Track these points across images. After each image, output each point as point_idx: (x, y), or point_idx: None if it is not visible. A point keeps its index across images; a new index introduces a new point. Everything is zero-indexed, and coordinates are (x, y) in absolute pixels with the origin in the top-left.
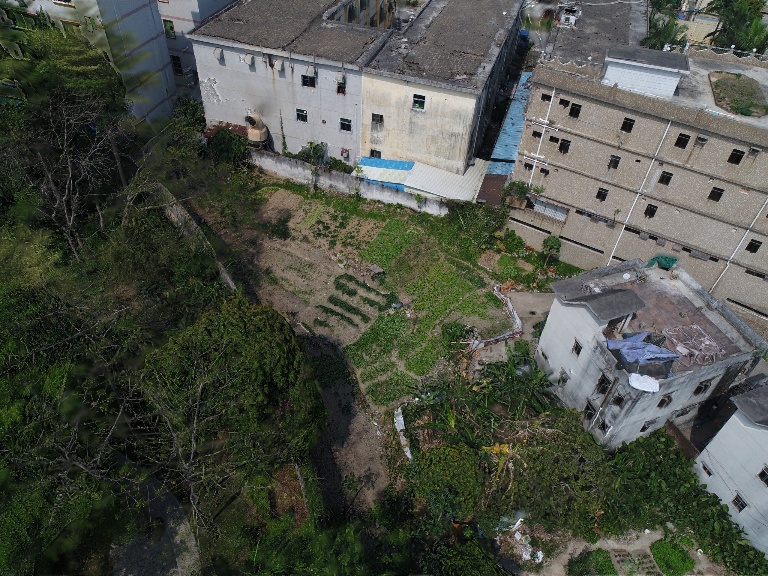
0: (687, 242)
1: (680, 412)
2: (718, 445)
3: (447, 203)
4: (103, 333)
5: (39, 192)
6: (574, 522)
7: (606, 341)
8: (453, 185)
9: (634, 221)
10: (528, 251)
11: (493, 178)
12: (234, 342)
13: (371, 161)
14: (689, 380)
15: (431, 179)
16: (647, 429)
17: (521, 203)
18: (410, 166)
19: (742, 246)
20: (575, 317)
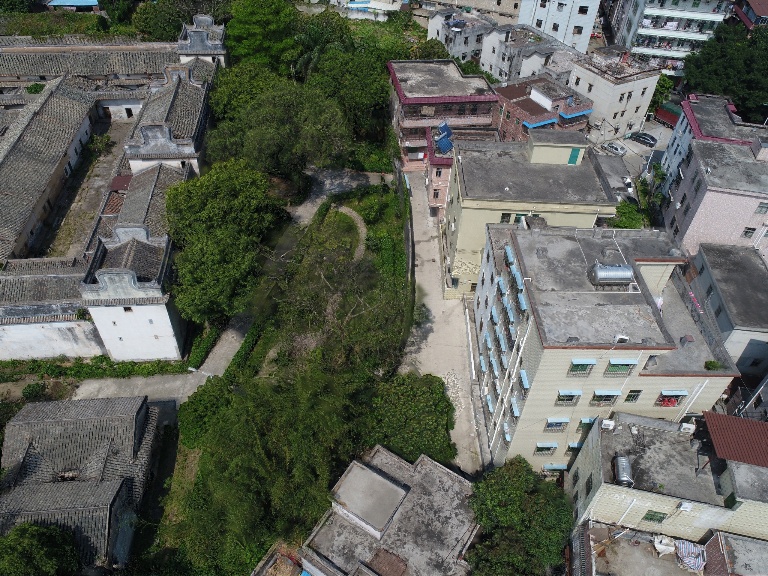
0: (478, 7)
1: (475, 52)
2: (483, 52)
3: (387, 13)
4: (295, 8)
5: (228, 4)
6: (436, 58)
7: (445, 22)
8: (388, 7)
9: (459, 3)
10: (423, 29)
11: (405, 4)
12: (330, 16)
13: (351, 3)
14: (472, 32)
15: (379, 5)
16: (465, 60)
17: (417, 6)
18: (369, 2)
19: (495, 3)
20: (435, 21)
